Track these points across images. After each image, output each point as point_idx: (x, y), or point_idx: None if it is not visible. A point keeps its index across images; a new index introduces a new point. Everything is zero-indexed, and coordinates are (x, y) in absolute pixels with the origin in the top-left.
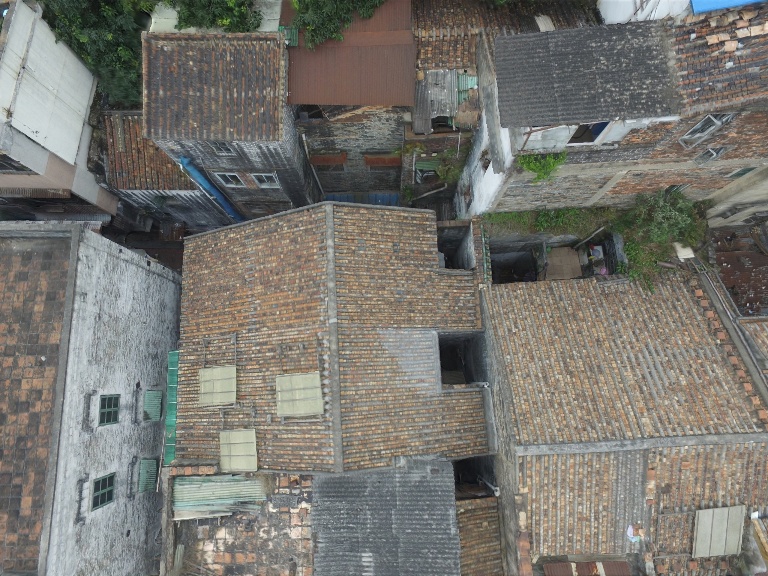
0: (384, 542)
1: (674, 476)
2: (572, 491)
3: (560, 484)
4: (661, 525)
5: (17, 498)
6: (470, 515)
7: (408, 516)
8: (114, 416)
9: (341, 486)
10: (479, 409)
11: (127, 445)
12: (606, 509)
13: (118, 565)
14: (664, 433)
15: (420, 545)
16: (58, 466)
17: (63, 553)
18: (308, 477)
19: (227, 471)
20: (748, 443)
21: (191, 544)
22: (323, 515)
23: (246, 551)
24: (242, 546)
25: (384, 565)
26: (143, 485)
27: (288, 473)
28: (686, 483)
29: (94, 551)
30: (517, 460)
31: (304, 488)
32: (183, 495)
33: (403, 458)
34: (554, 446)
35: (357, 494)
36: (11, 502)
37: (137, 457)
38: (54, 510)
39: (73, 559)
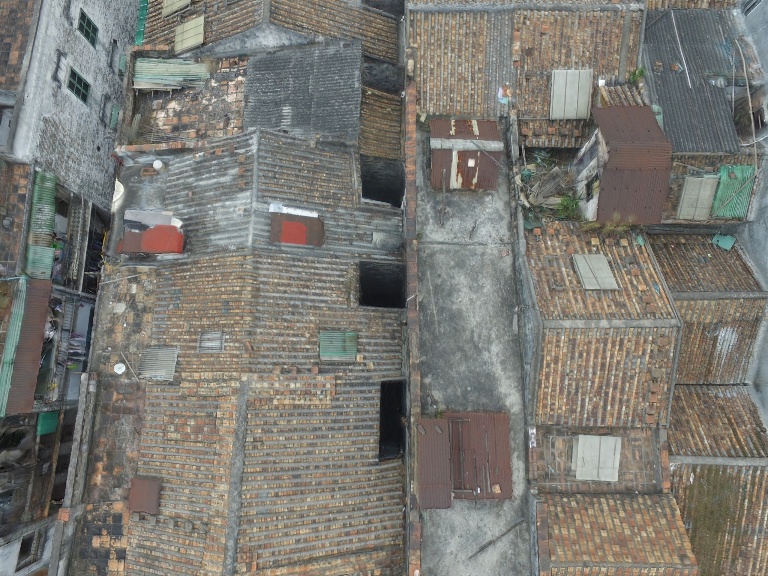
0: (301, 99)
1: (537, 41)
2: (454, 52)
3: (443, 42)
4: (526, 90)
5: (7, 52)
6: (376, 99)
7: (322, 79)
8: (92, 40)
9: (271, 63)
10: (393, 31)
11: (102, 78)
12: (481, 71)
13: (88, 162)
14: (529, 1)
15: (330, 98)
16: (41, 16)
17: (41, 89)
18: (245, 58)
19: (179, 51)
20: (596, 12)
21: (147, 113)
22: (254, 83)
23: (190, 114)
24: (188, 111)
25: (300, 114)
26: (114, 123)
27: (227, 43)
28: (546, 48)
29: (67, 123)
30: (408, 13)
31: (241, 67)
32: (142, 69)
33: (322, 36)
34: (439, 4)
35: (283, 67)
36: (2, 55)
37: (110, 98)
38: (35, 45)
39: (49, 104)
